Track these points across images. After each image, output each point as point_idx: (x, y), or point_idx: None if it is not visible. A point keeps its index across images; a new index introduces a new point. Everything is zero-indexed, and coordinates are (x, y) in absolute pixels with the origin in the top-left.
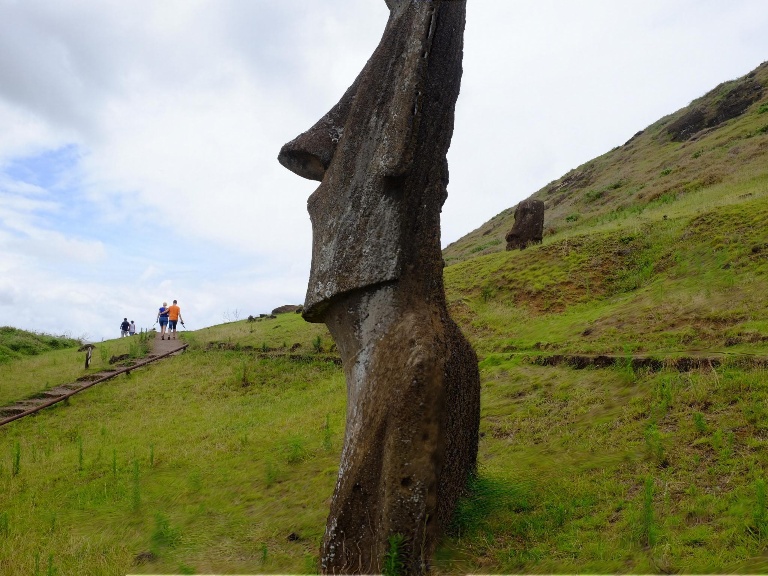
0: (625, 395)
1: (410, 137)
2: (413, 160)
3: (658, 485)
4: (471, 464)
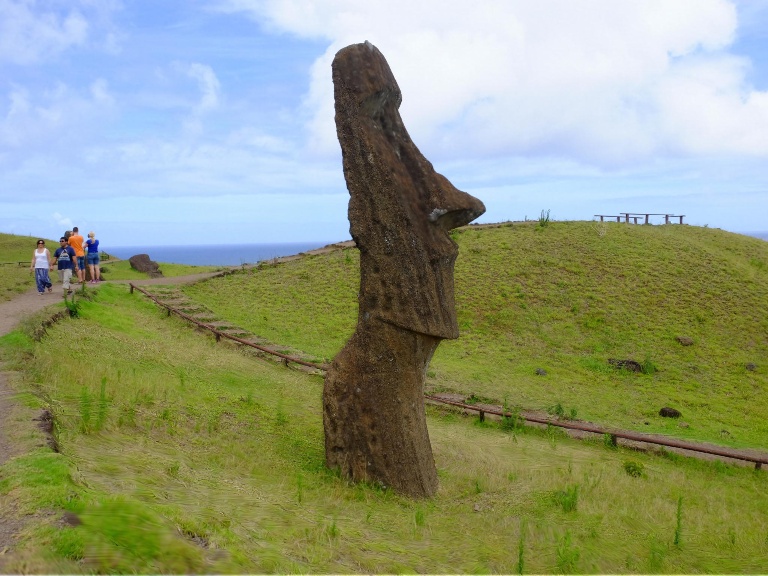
0: (120, 441)
1: None
2: None
3: None
4: None
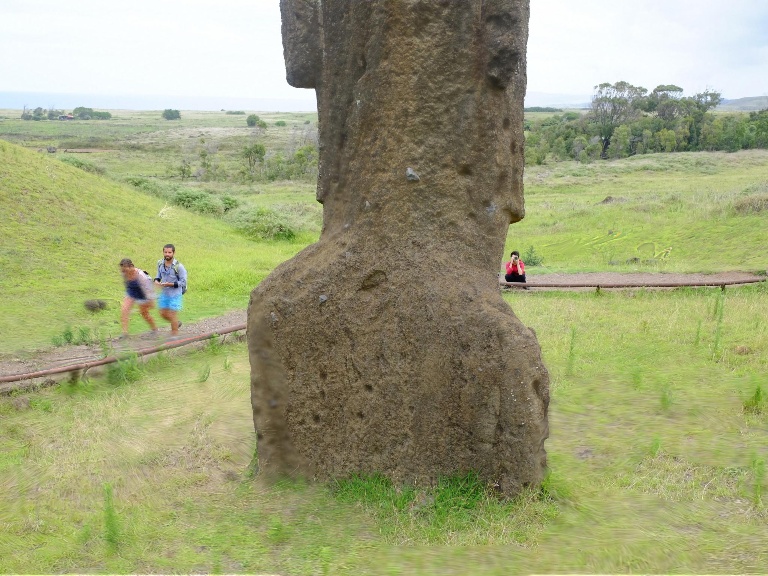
0: None
1: (284, 34)
2: (292, 61)
3: (222, 574)
4: (504, 474)
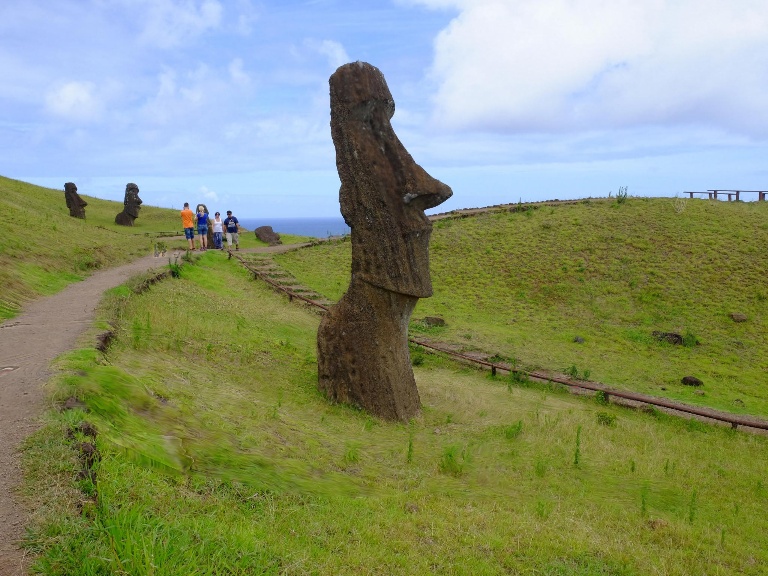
0: None
1: None
2: None
3: None
4: None
